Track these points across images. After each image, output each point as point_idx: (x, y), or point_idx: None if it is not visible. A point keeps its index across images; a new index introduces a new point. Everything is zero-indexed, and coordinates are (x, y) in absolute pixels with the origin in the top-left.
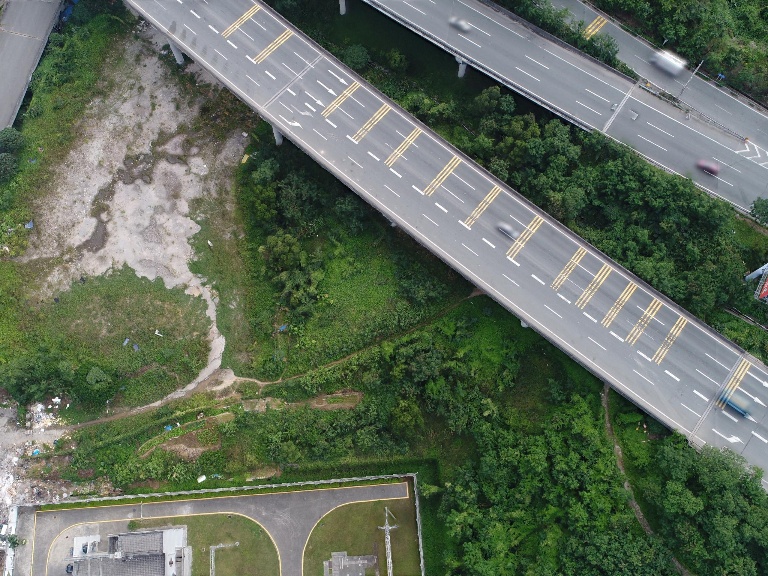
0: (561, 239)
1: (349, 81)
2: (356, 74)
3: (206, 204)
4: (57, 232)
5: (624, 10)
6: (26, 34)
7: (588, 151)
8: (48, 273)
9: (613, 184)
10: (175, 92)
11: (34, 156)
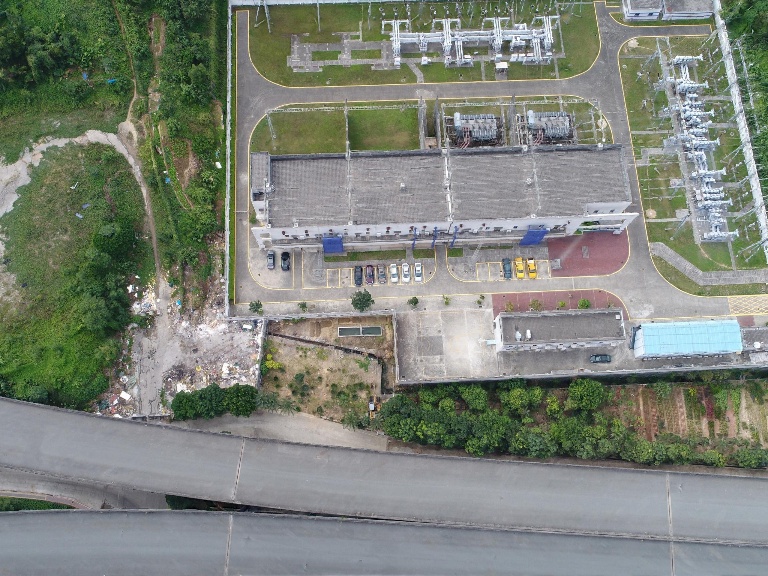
0: None
1: None
2: None
3: None
4: None
5: None
6: None
7: None
8: None
9: None
10: None
11: None
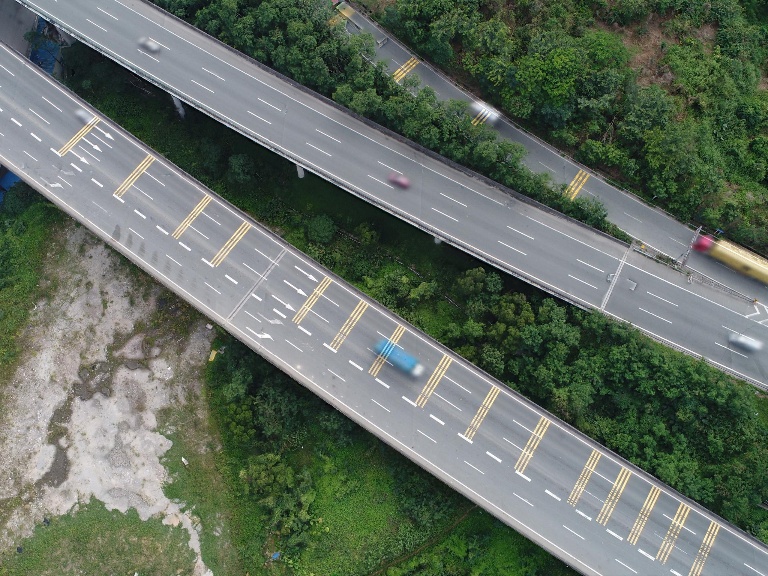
0: (572, 442)
1: (319, 277)
2: (326, 269)
3: (175, 414)
4: (12, 467)
5: (607, 165)
6: None
7: (587, 330)
8: (6, 518)
9: (620, 372)
10: (127, 285)
11: None
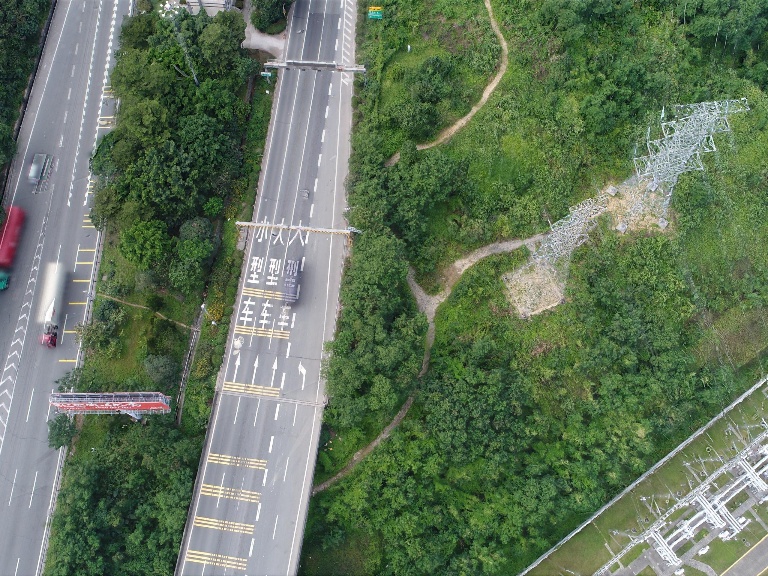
0: None
1: None
2: None
3: None
4: None
5: None
6: None
7: None
8: None
9: None
10: None
11: None
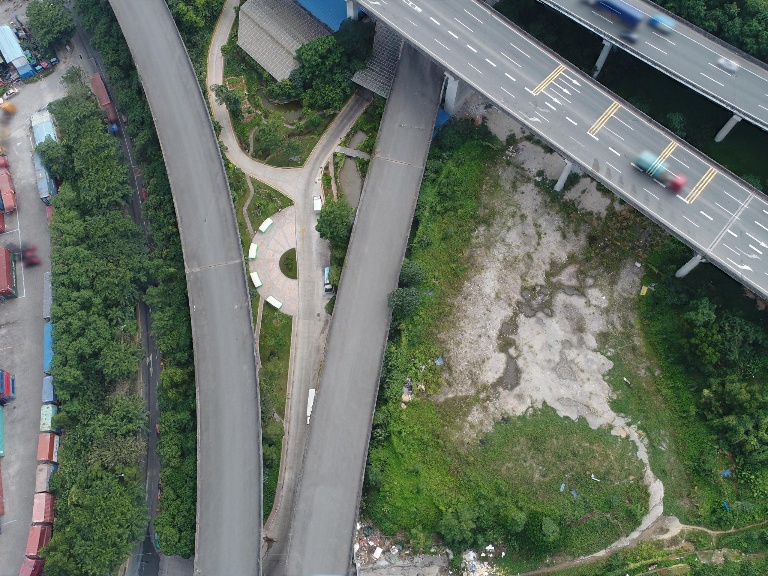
0: None
1: None
2: None
3: (613, 338)
4: (468, 368)
5: None
6: (403, 161)
7: None
8: (467, 413)
9: None
10: (558, 220)
11: (431, 288)
